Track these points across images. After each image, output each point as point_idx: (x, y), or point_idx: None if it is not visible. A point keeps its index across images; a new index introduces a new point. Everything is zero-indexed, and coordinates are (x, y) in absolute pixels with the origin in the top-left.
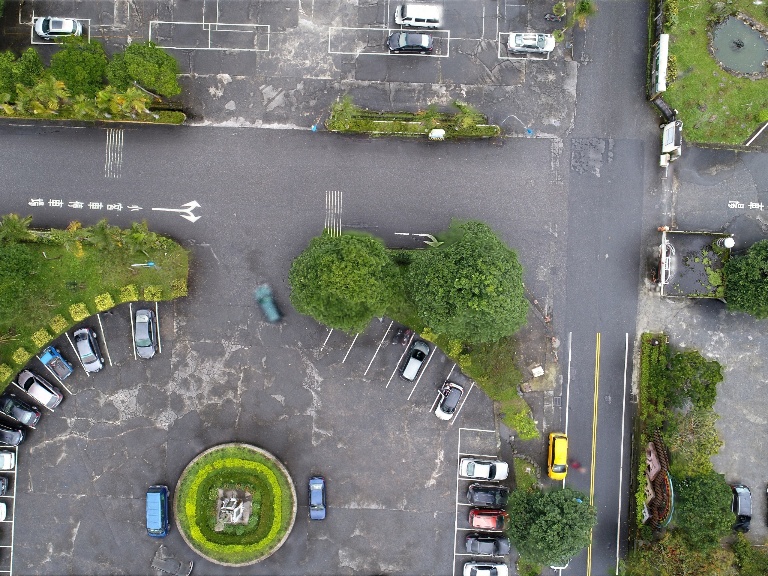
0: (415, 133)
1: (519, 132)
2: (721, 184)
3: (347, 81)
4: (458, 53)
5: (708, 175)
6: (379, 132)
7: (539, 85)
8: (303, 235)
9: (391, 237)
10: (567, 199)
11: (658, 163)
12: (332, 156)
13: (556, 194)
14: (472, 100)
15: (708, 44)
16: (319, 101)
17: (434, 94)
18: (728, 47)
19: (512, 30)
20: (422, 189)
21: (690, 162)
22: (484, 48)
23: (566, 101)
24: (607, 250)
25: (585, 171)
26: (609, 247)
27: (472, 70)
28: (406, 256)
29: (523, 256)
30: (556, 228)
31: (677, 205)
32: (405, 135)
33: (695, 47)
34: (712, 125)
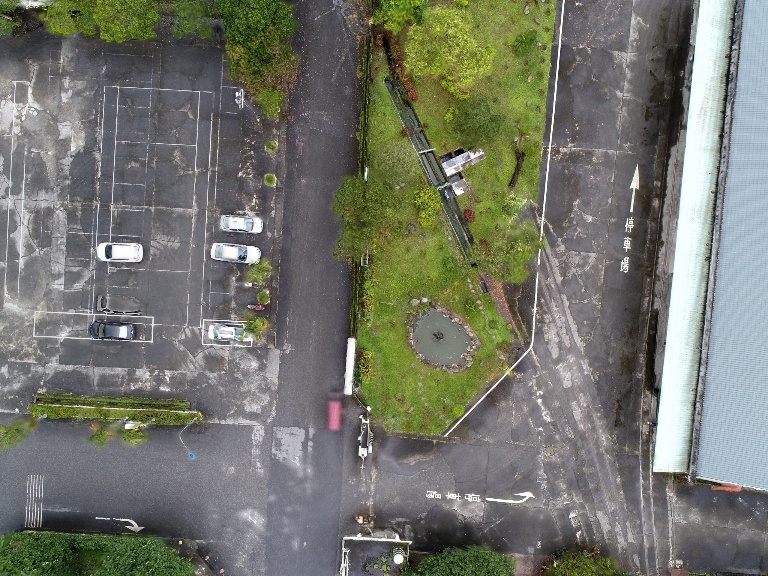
0: (118, 418)
1: (221, 418)
2: (419, 474)
3: (51, 365)
4: (162, 339)
5: (407, 465)
6: (82, 417)
7: (242, 372)
8: (4, 518)
9: (92, 521)
10: (267, 487)
11: (357, 453)
12: (35, 440)
13: (256, 482)
14: (175, 386)
15: (407, 337)
16: (23, 384)
17: (138, 379)
18: (429, 338)
19: (216, 317)
20: (123, 474)
21: (389, 452)
22: (188, 335)
23: (268, 389)
24: (305, 538)
25: (285, 459)
26: (307, 535)
27: (176, 356)
28: (102, 545)
29: (223, 542)
30: (255, 515)
31: (375, 494)
32: (108, 420)
33: (395, 339)
34: (411, 416)
